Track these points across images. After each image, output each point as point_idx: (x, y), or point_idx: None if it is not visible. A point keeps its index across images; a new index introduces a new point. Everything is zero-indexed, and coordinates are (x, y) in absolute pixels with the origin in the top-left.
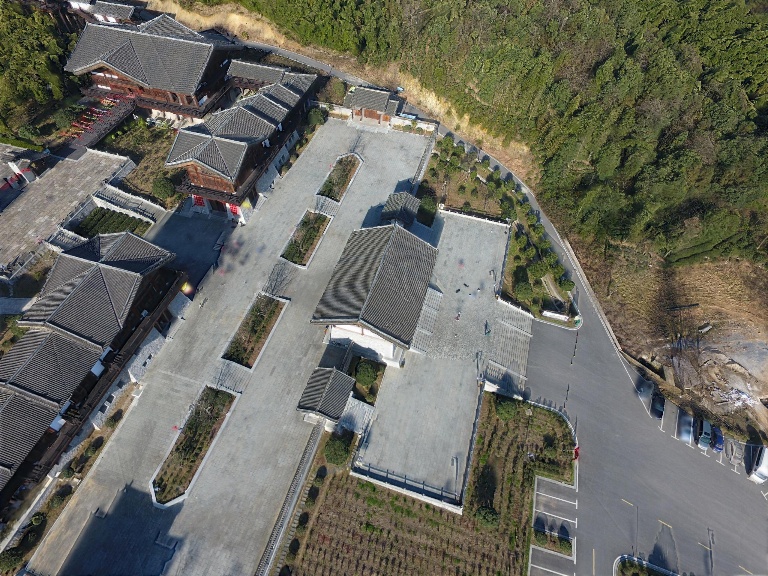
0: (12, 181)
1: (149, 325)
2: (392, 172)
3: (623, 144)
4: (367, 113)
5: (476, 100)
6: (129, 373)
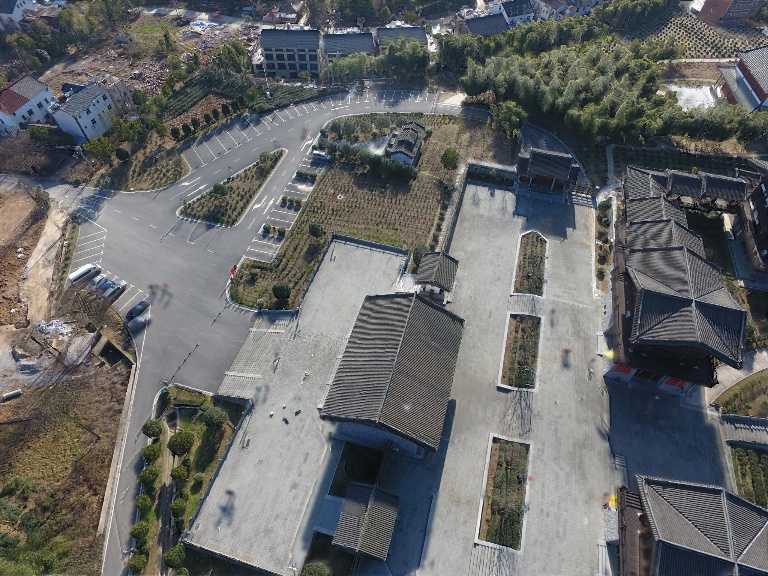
0: None
1: None
2: None
3: None
4: None
5: None
6: None
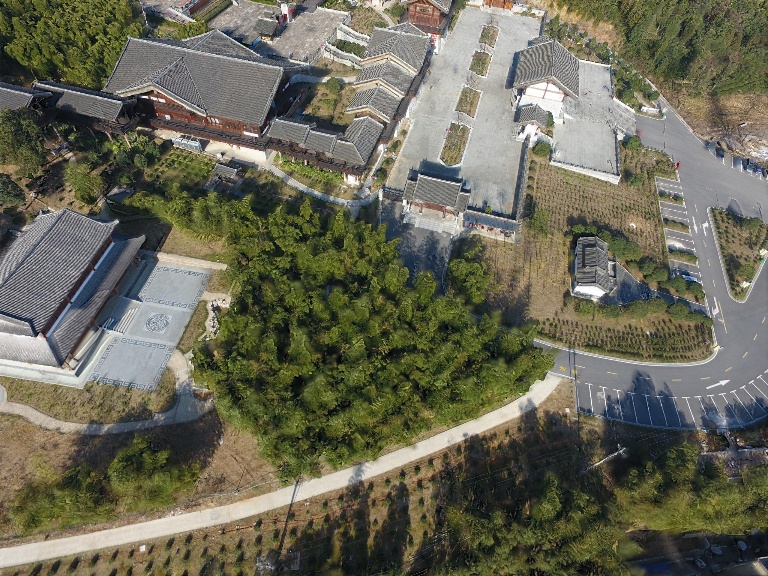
0: (282, 18)
1: (421, 79)
2: (522, 36)
3: (682, 18)
4: (494, 3)
5: None
6: (407, 110)
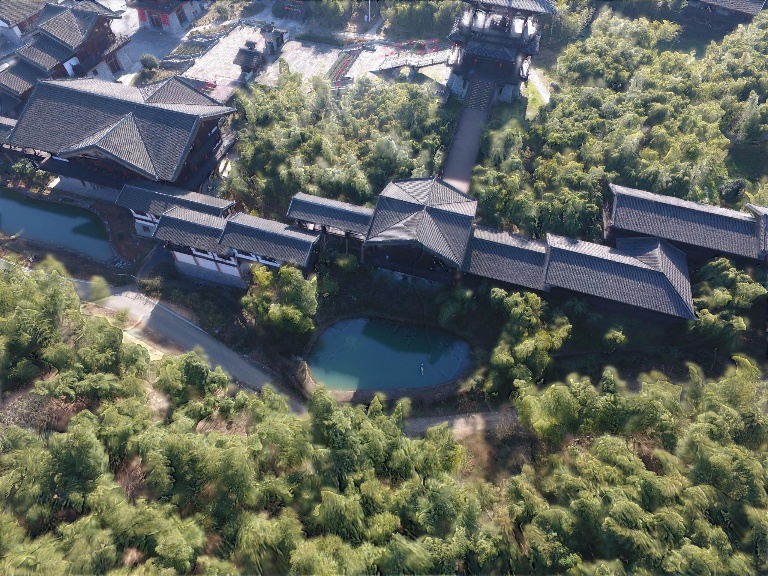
0: None
1: None
2: None
3: None
4: None
5: None
6: None
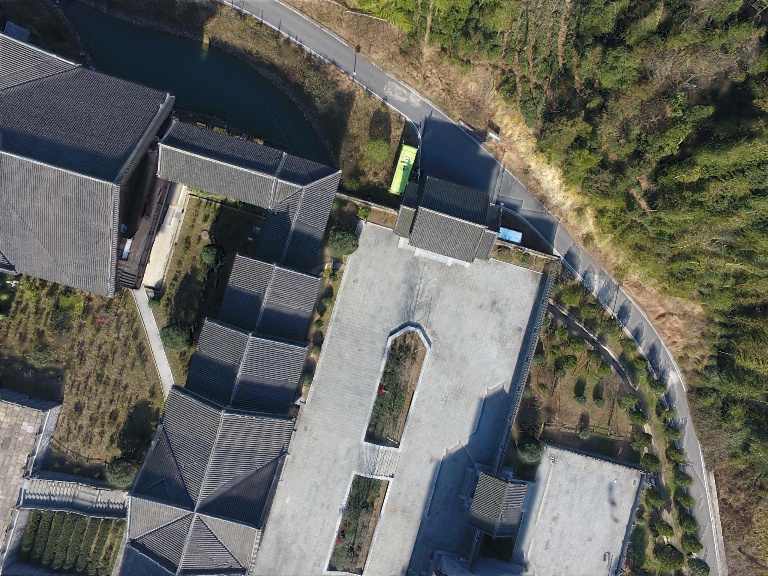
0: None
1: None
2: (477, 369)
3: None
4: None
5: (640, 208)
6: None
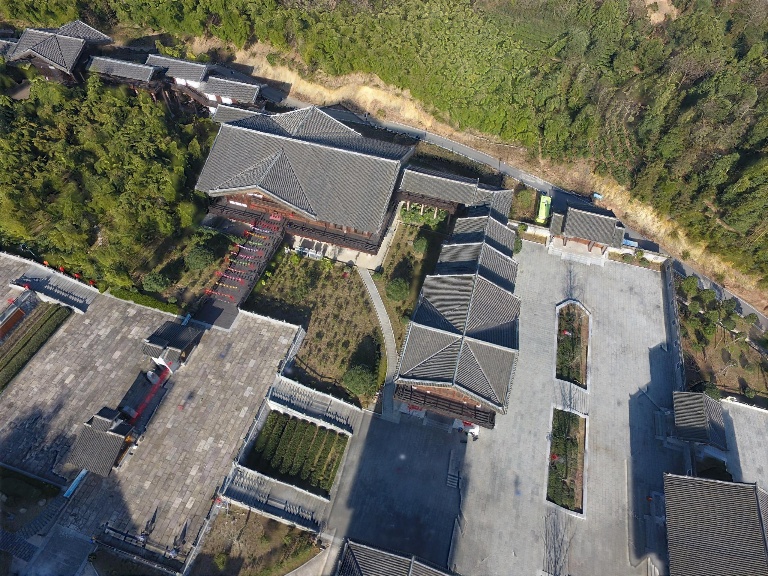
0: (153, 377)
1: None
2: (634, 332)
3: None
4: None
5: (716, 223)
6: None
